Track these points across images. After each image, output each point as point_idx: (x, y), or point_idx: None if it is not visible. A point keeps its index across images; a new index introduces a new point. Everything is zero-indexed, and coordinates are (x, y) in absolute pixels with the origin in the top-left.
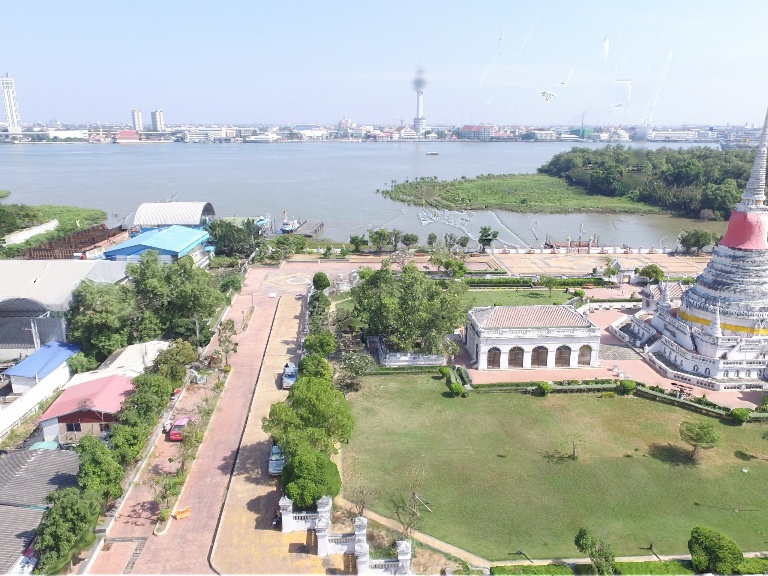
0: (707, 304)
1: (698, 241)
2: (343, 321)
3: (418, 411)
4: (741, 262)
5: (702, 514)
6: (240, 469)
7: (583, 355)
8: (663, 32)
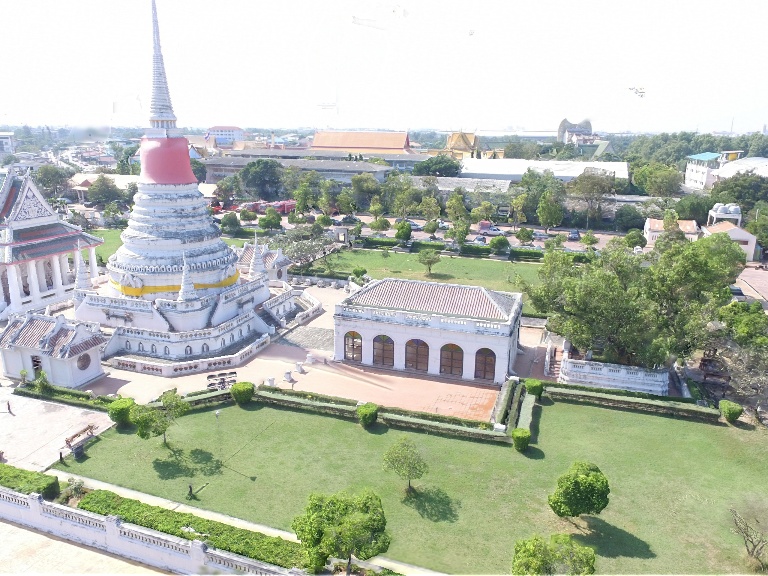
0: None
1: None
2: None
3: None
4: None
5: None
6: (764, 301)
7: None
8: None
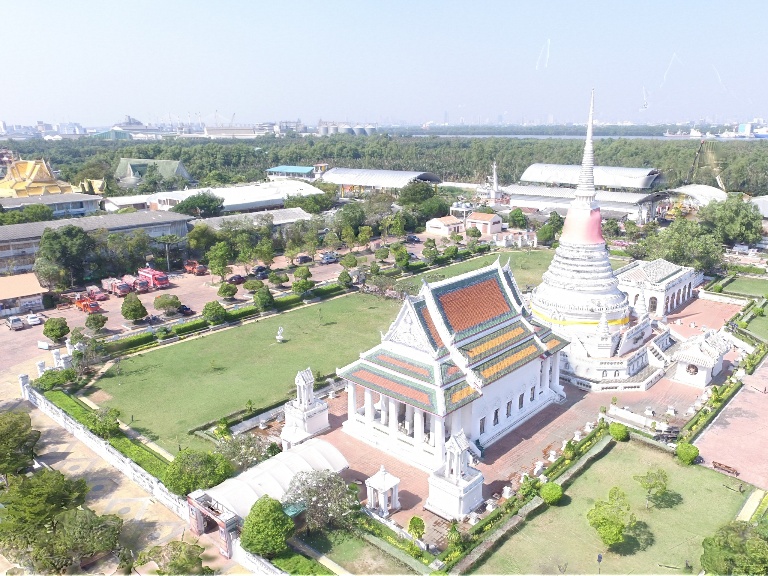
0: None
1: None
2: (764, 280)
3: None
4: None
5: (468, 269)
6: None
7: None
8: None
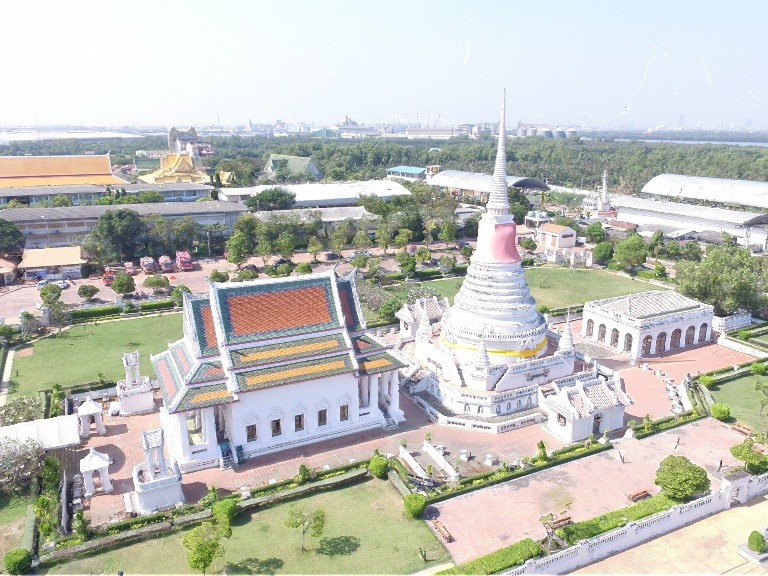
0: None
1: None
2: None
3: (632, 292)
4: None
5: None
6: None
7: None
8: None
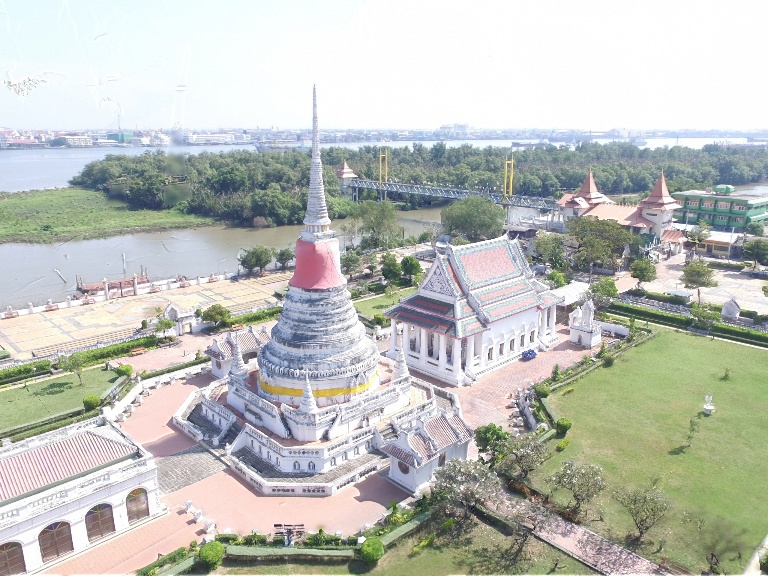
0: (292, 369)
1: (259, 260)
2: None
3: None
4: (320, 307)
5: None
6: None
7: (134, 506)
8: (164, 1)
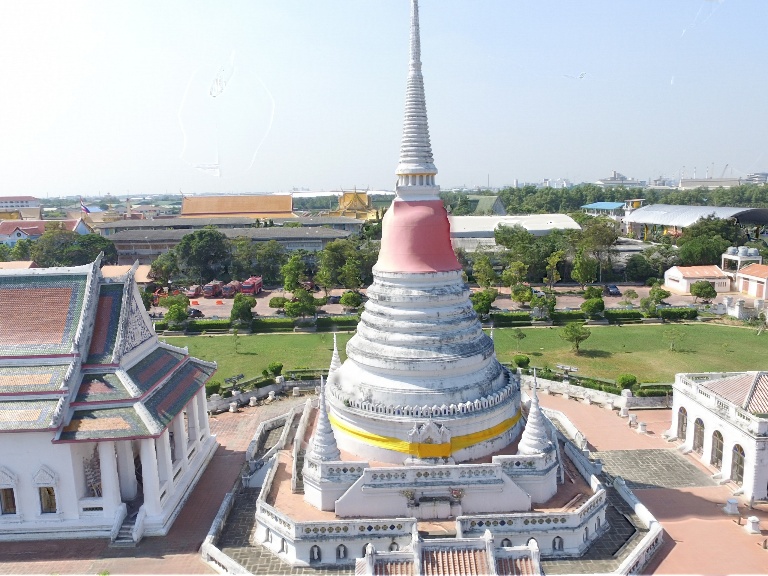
0: None
1: None
2: None
3: None
4: None
5: None
6: None
7: None
8: None
